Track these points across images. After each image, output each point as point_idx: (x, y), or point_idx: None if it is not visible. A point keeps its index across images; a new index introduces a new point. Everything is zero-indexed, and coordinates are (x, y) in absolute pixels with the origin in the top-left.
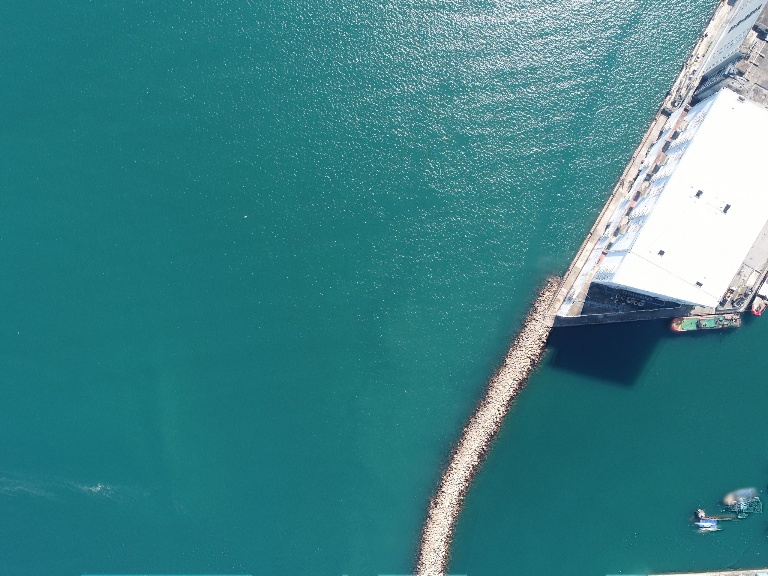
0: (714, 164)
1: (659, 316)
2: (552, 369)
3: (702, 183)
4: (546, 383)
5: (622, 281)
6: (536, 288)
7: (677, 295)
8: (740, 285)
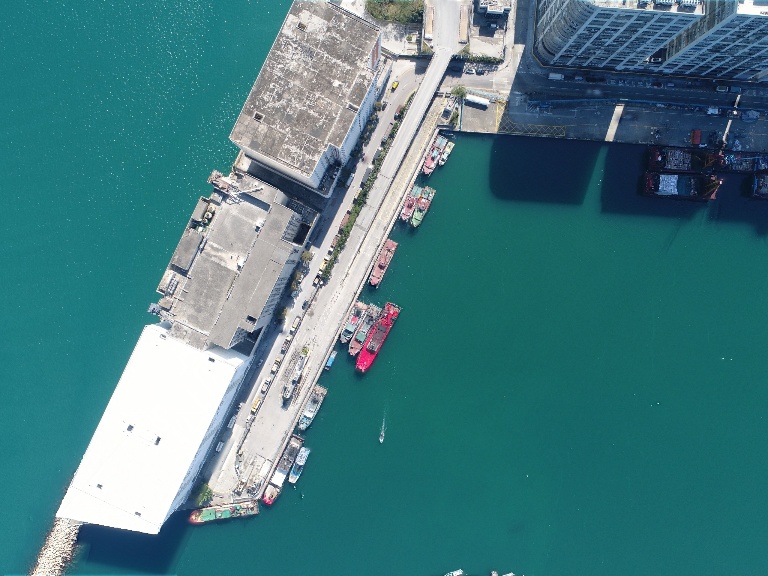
0: (142, 399)
1: (180, 508)
2: (86, 564)
3: (133, 417)
4: None
5: (66, 515)
6: (64, 487)
7: (118, 525)
8: (254, 474)
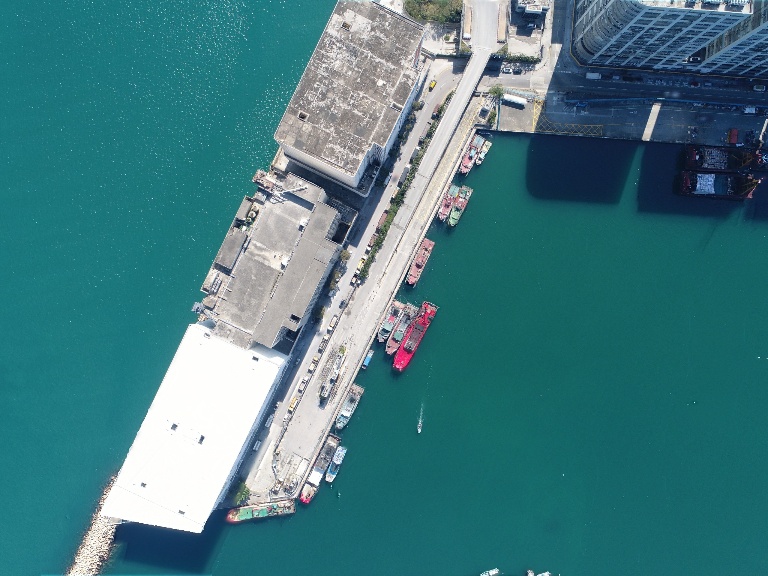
0: (186, 398)
1: (218, 507)
2: (123, 563)
3: (177, 416)
4: (120, 575)
5: (109, 513)
6: (101, 486)
7: (162, 524)
8: (291, 473)
